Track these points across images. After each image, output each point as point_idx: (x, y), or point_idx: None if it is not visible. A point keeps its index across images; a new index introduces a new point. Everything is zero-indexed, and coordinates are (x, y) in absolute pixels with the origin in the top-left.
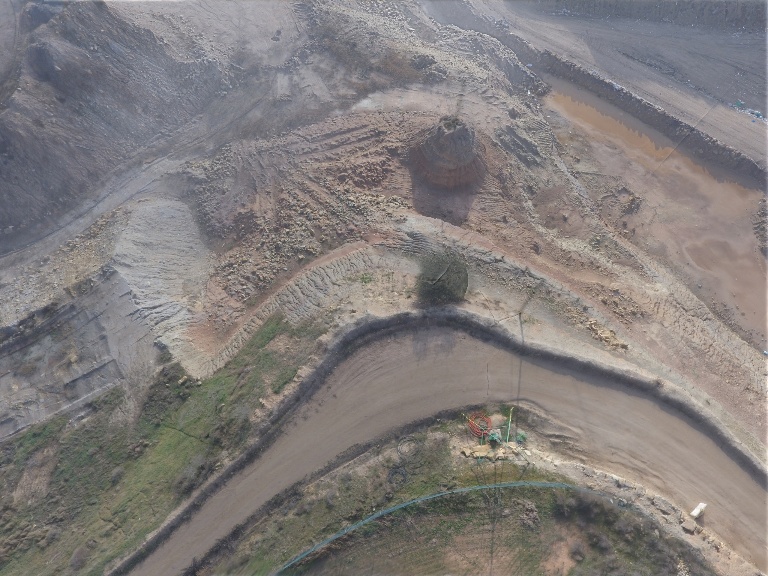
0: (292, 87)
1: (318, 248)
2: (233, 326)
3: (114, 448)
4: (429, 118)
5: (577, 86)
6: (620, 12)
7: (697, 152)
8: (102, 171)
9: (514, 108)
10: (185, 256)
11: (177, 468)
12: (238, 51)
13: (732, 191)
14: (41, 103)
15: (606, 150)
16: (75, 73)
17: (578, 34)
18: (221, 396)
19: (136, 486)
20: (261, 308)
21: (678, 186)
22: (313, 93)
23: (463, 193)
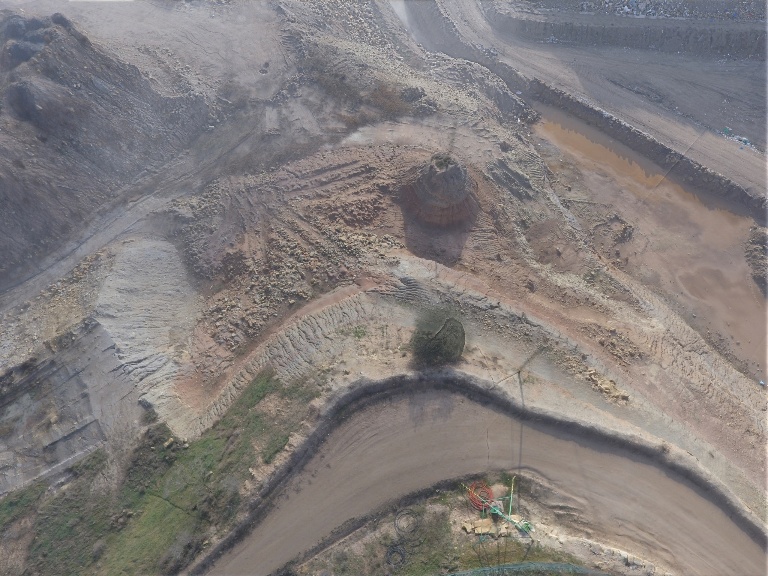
0: (281, 121)
1: (309, 292)
2: (222, 378)
3: (96, 519)
4: (420, 154)
5: (566, 113)
6: (607, 40)
7: (687, 179)
8: (85, 211)
9: (505, 141)
10: (172, 300)
11: (162, 544)
12: (225, 84)
13: (723, 218)
14: (21, 143)
15: (597, 178)
16: (57, 111)
17: (566, 62)
18: (209, 462)
19: (119, 563)
20: (251, 360)
21: (669, 214)
22: (302, 127)
23: (456, 231)
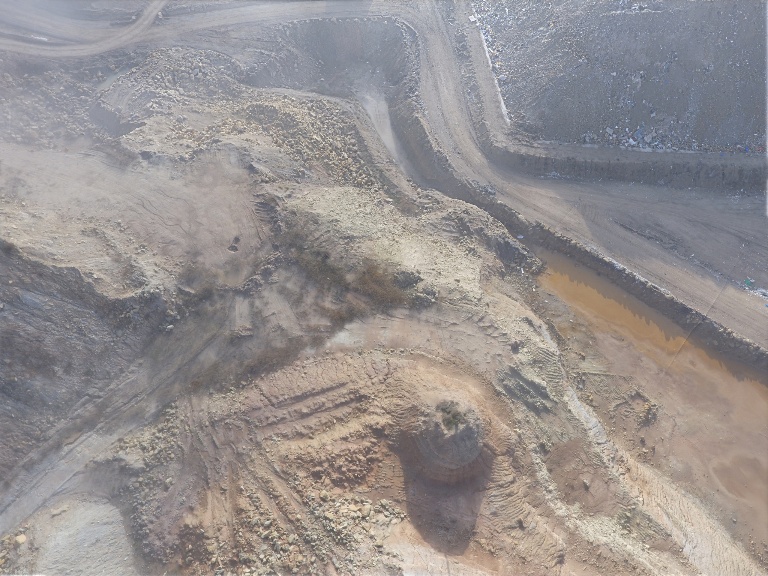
0: (253, 316)
1: None
2: None
3: None
4: (421, 380)
5: (574, 262)
6: (613, 175)
7: (711, 343)
8: (6, 467)
9: (516, 338)
10: None
11: None
12: (188, 267)
13: (754, 392)
14: None
15: (613, 343)
16: None
17: (570, 201)
18: None
19: None
20: None
21: (695, 387)
22: (279, 325)
23: (468, 490)
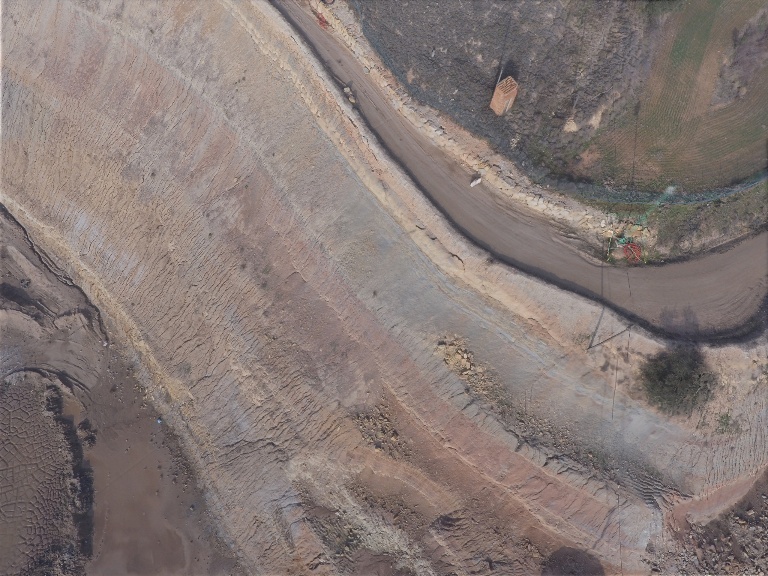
0: None
1: (733, 525)
2: None
3: None
4: None
5: None
6: None
7: None
8: None
9: None
10: None
11: None
12: None
13: None
14: None
15: None
16: None
17: None
18: None
19: None
20: None
21: None
22: None
23: None
